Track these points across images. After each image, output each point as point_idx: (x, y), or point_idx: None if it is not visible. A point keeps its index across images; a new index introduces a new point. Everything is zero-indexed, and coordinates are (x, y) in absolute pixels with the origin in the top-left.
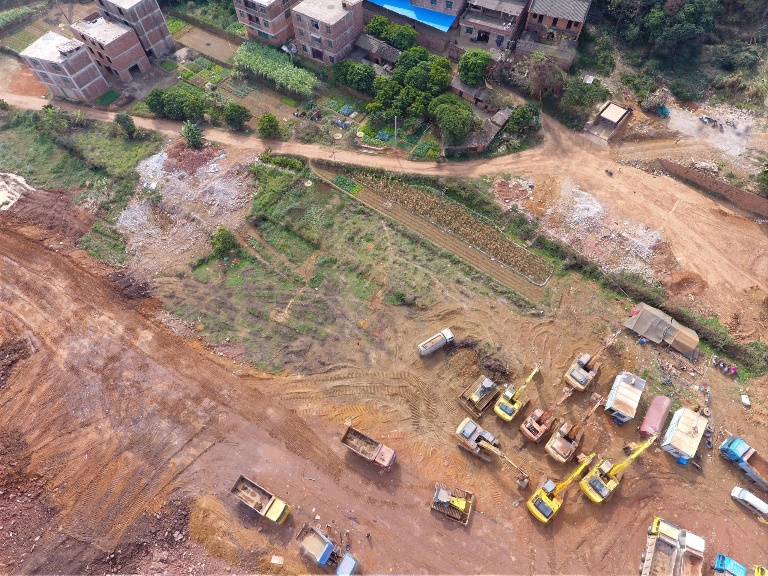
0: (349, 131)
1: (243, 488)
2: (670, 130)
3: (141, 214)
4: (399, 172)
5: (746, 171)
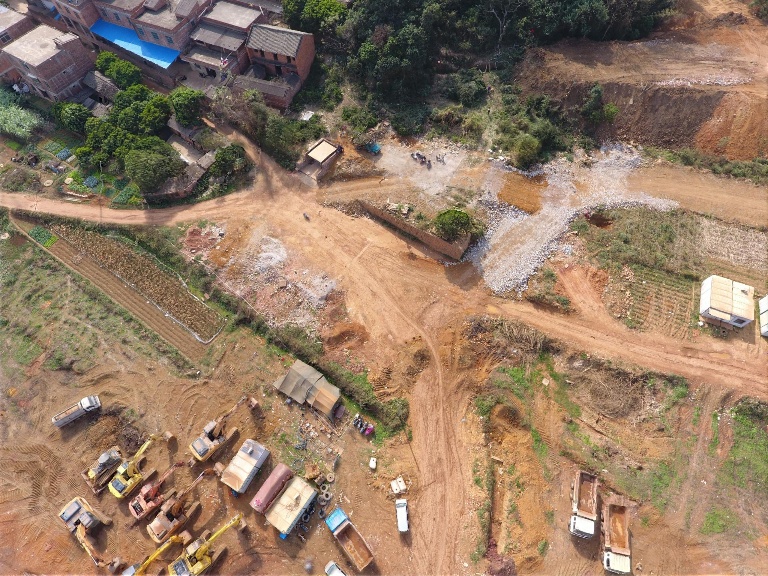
0: (60, 177)
1: None
2: (376, 169)
3: None
4: (95, 222)
5: (438, 211)
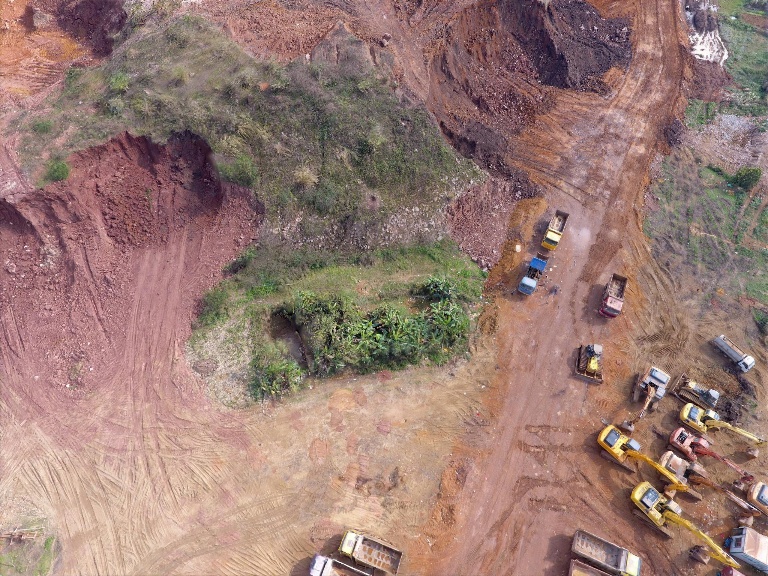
0: None
1: (560, 219)
2: None
3: (739, 126)
4: None
5: None
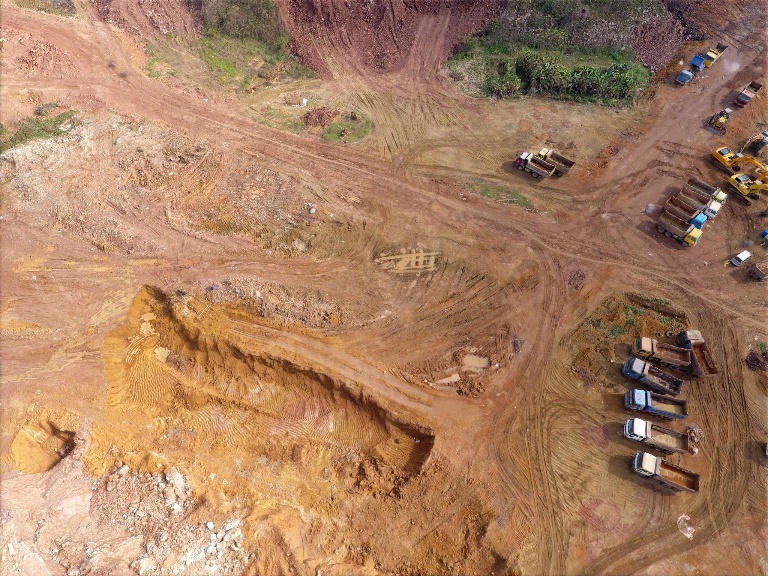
0: None
1: (719, 50)
2: None
3: None
4: None
5: None
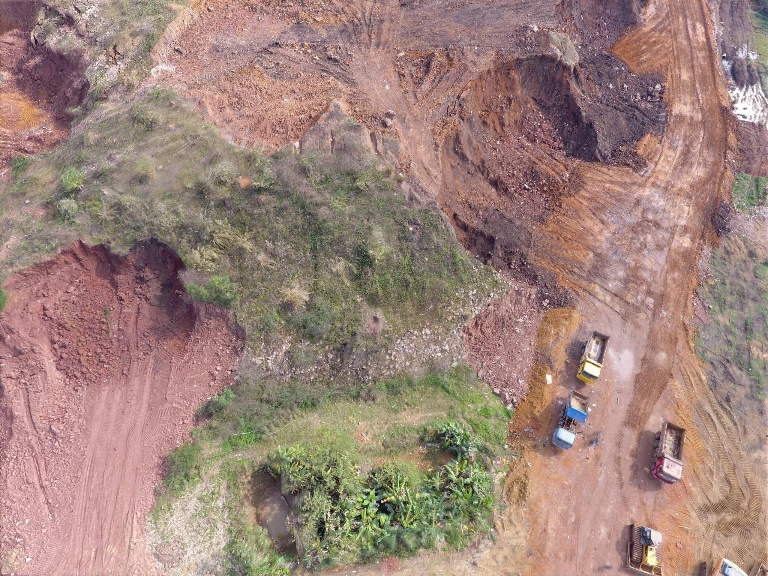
0: None
1: (597, 341)
2: None
3: None
4: None
5: None
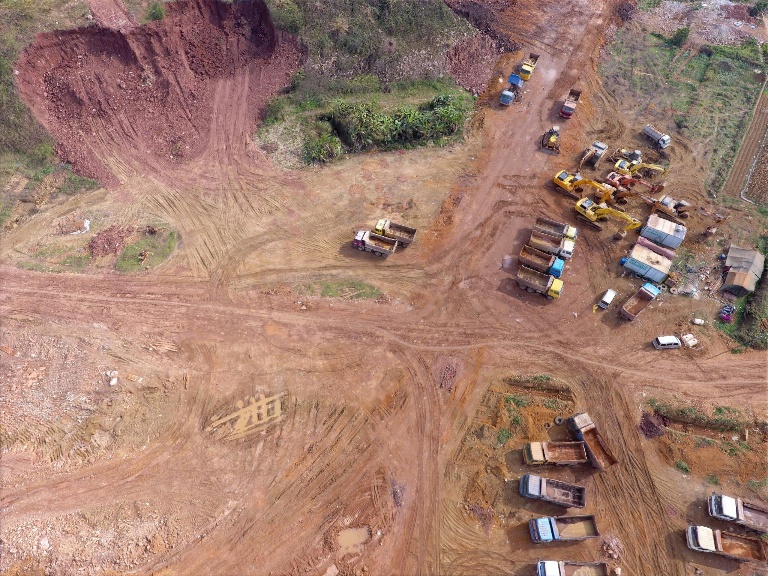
0: None
1: (533, 60)
2: None
3: (679, 9)
4: None
5: None
